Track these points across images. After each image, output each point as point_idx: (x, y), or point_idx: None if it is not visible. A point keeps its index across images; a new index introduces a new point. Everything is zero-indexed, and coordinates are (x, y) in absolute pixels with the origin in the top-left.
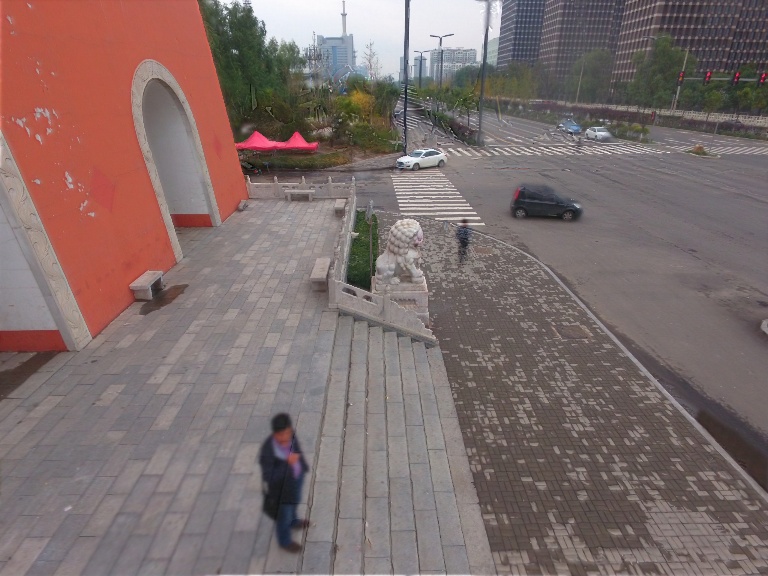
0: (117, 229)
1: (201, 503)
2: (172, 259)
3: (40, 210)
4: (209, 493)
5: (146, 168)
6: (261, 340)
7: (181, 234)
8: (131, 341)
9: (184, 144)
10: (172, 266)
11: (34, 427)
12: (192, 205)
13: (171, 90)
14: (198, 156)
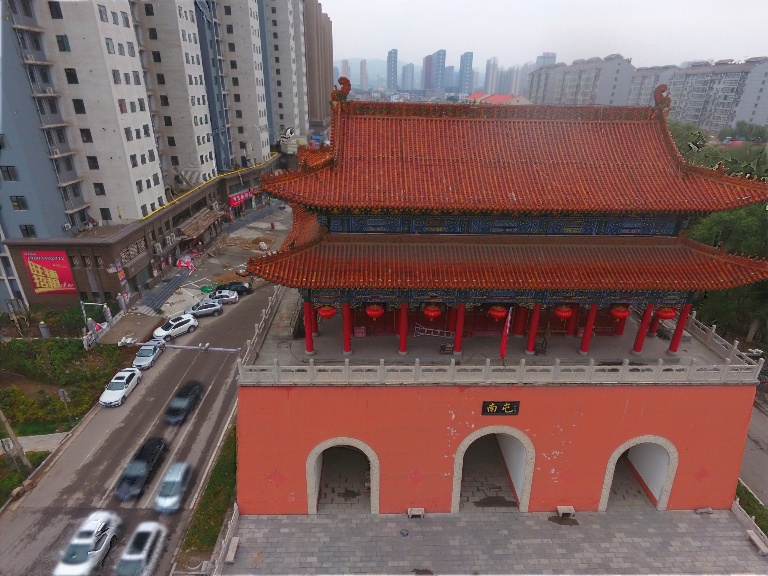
0: (567, 489)
1: (473, 572)
2: (595, 508)
3: (535, 476)
4: (476, 573)
5: (605, 474)
6: (546, 568)
7: (635, 497)
8: (530, 524)
9: (664, 466)
10: (593, 511)
11: (487, 521)
12: (654, 490)
13: (663, 446)
14: (667, 476)
